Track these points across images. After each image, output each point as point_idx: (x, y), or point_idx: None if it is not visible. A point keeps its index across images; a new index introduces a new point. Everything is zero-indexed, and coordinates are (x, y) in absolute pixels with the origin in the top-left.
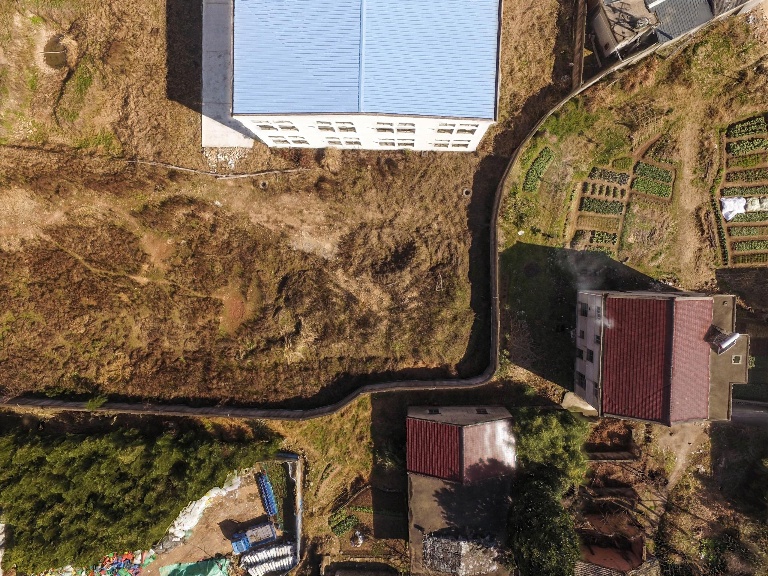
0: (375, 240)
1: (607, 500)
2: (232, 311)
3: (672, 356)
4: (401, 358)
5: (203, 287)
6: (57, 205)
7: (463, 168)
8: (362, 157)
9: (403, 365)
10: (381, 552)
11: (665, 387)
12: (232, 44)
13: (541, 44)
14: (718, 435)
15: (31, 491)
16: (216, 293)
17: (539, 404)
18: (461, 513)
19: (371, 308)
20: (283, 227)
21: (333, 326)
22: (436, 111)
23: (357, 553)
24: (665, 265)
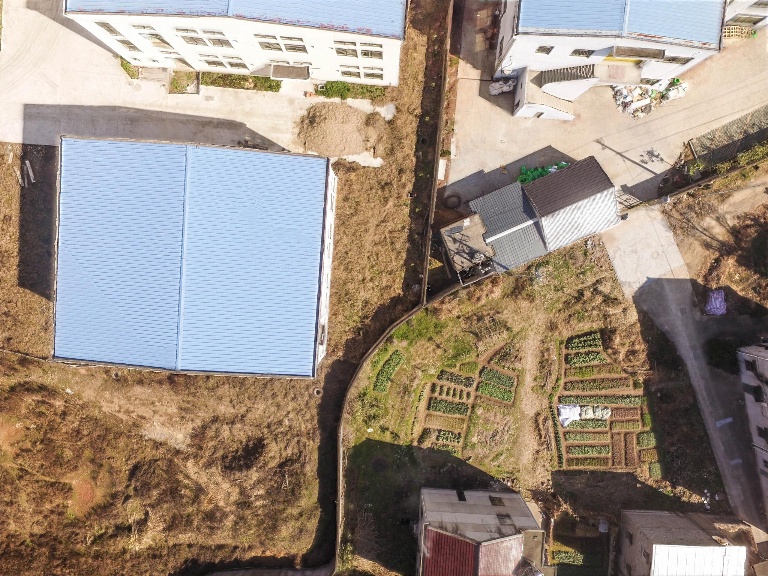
0: (227, 433)
1: None
2: (82, 495)
3: None
4: (249, 547)
5: (52, 472)
6: None
7: None
8: None
9: (251, 554)
10: None
11: None
12: (56, 288)
13: (392, 256)
14: None
15: None
16: (65, 478)
17: None
18: None
19: (217, 504)
20: (135, 417)
21: (181, 517)
22: (254, 368)
23: None
24: (505, 465)
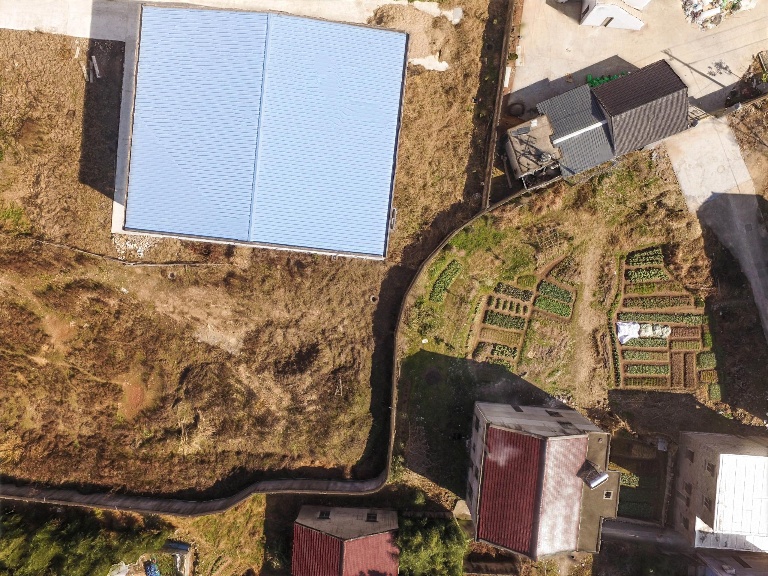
0: (280, 338)
1: None
2: (132, 397)
3: (542, 494)
4: (298, 457)
5: (103, 372)
6: None
7: (371, 275)
8: (272, 257)
9: (300, 463)
10: None
11: (534, 523)
12: (129, 158)
13: (454, 162)
14: (600, 550)
15: None
16: (116, 379)
17: (431, 510)
18: None
19: (270, 408)
20: (189, 319)
21: (232, 421)
22: (326, 244)
23: None
24: (561, 382)
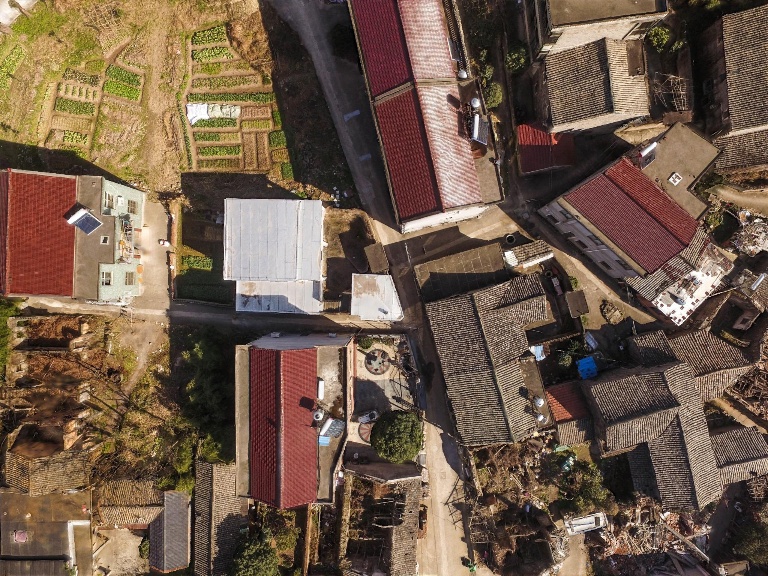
0: None
1: (68, 397)
2: None
3: (7, 226)
4: None
5: None
6: None
7: None
8: None
9: None
10: None
11: (5, 258)
12: None
13: None
14: (176, 335)
15: None
16: None
17: None
18: None
19: None
20: None
21: None
22: None
23: None
24: (134, 167)
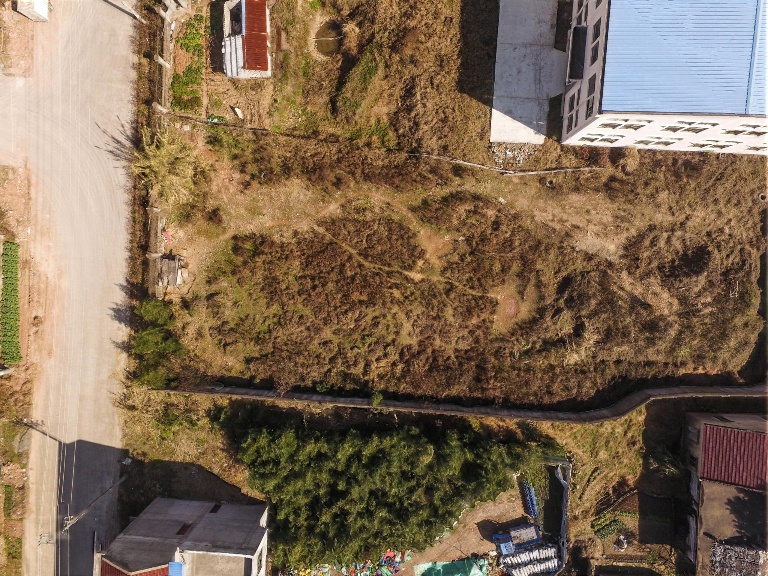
0: (662, 243)
1: None
2: (506, 310)
3: None
4: (681, 363)
5: (480, 285)
6: (333, 197)
7: (761, 172)
8: (658, 157)
9: (682, 370)
10: (645, 557)
11: None
12: (604, 38)
13: None
14: None
15: (309, 487)
16: (492, 292)
17: None
18: (753, 522)
19: (662, 312)
20: (568, 227)
21: (616, 329)
22: None
23: (620, 557)
24: None
